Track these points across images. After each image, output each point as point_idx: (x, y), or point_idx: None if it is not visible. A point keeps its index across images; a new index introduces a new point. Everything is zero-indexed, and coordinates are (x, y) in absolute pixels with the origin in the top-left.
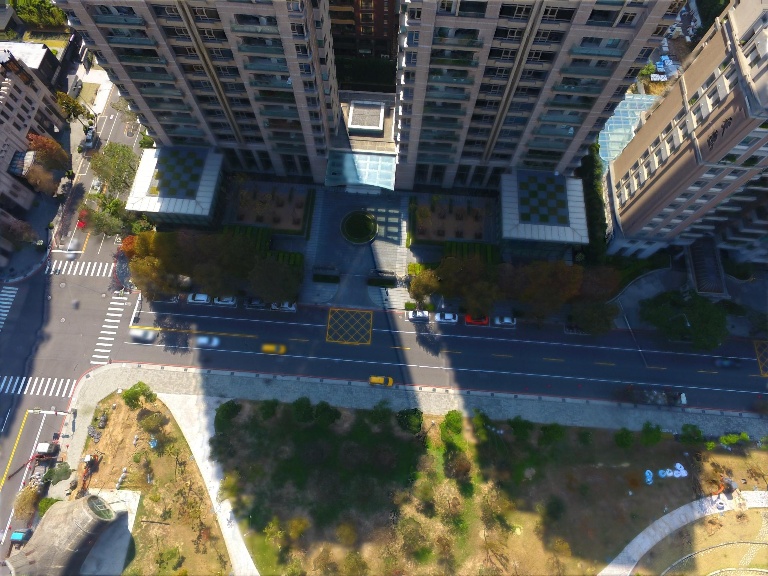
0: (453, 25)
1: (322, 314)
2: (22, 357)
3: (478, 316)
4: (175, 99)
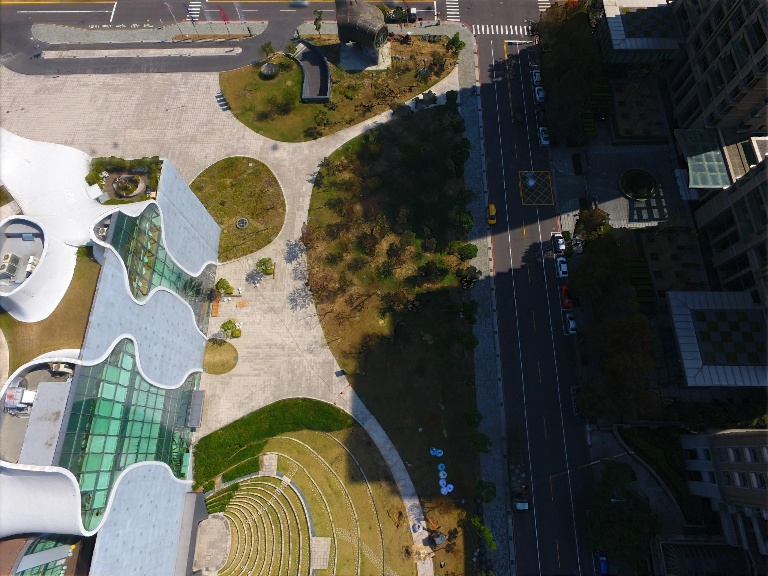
0: None
1: (543, 166)
2: None
3: (571, 290)
4: None
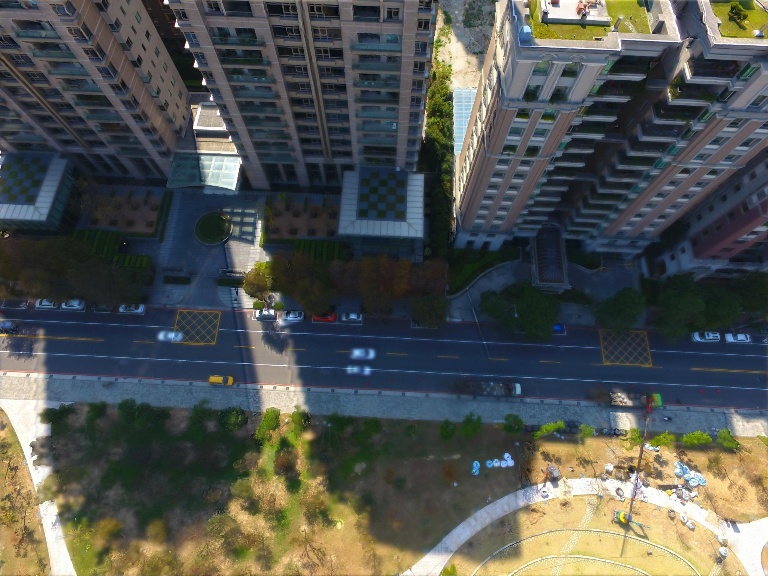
0: (227, 25)
1: (170, 316)
2: None
3: (320, 313)
4: (2, 106)
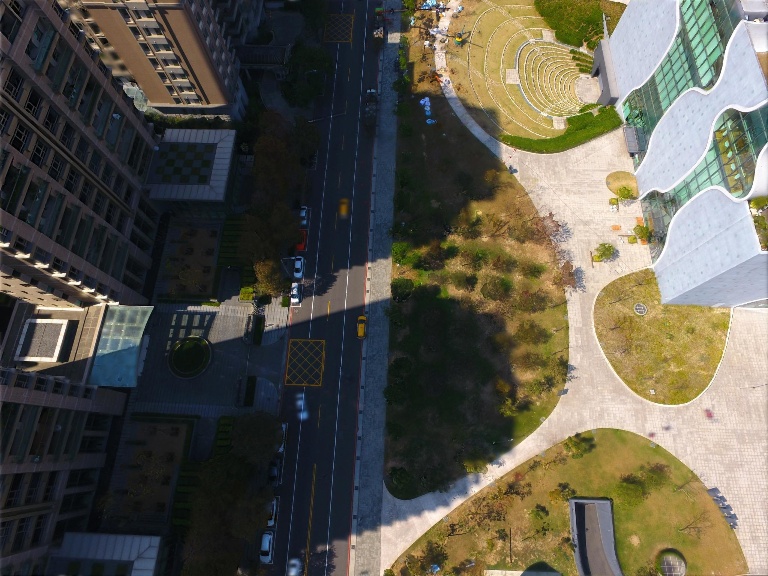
0: None
1: (291, 393)
2: None
3: None
4: None
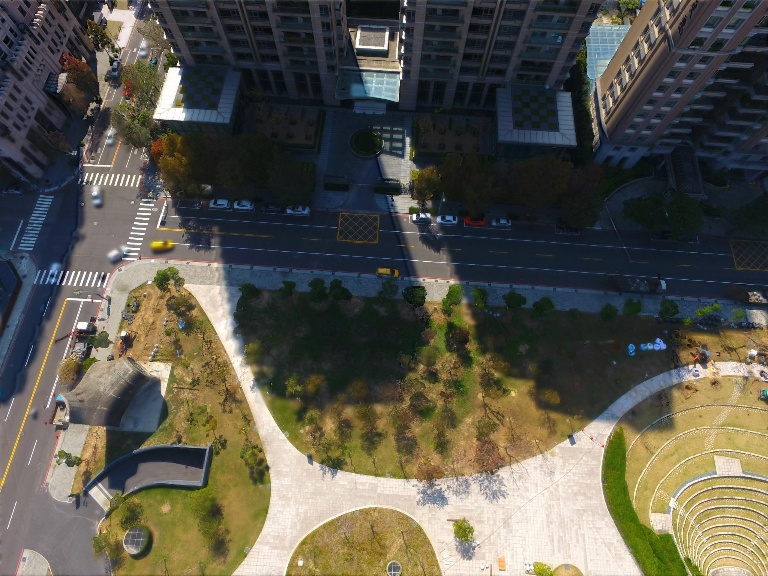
0: None
1: (333, 218)
2: (59, 254)
3: (476, 216)
4: (199, 14)
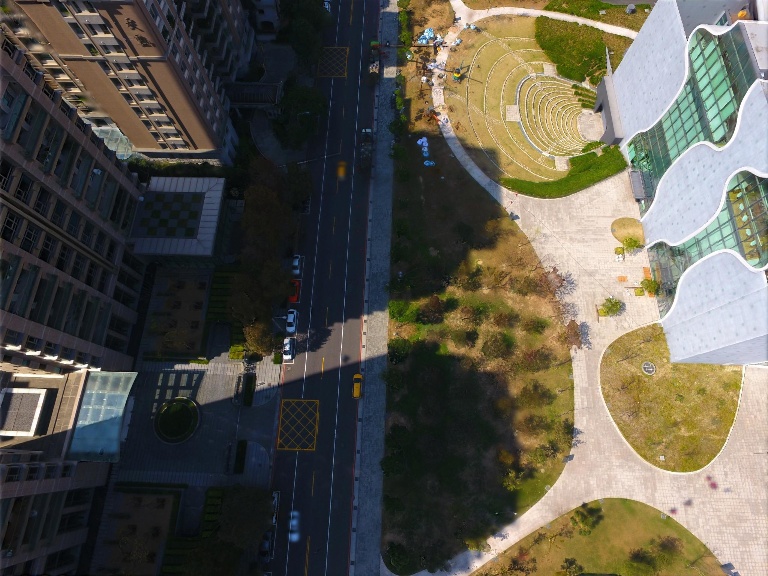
0: None
1: (283, 458)
2: None
3: None
4: None
